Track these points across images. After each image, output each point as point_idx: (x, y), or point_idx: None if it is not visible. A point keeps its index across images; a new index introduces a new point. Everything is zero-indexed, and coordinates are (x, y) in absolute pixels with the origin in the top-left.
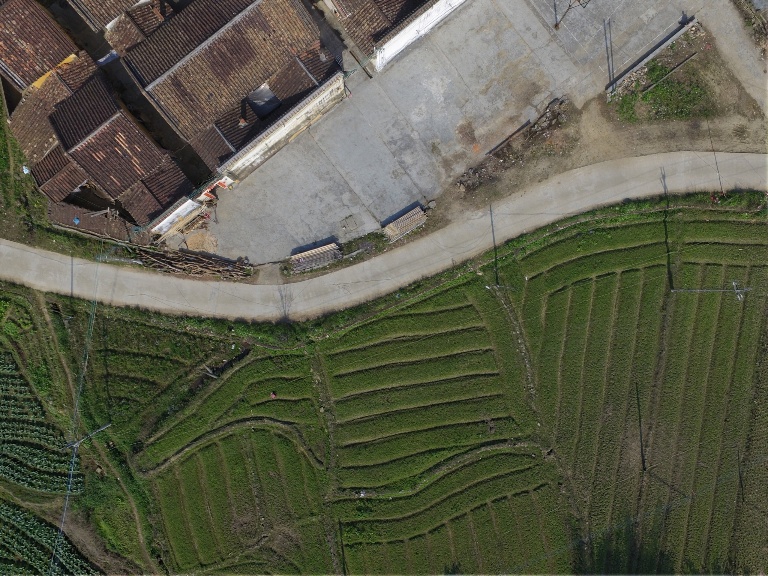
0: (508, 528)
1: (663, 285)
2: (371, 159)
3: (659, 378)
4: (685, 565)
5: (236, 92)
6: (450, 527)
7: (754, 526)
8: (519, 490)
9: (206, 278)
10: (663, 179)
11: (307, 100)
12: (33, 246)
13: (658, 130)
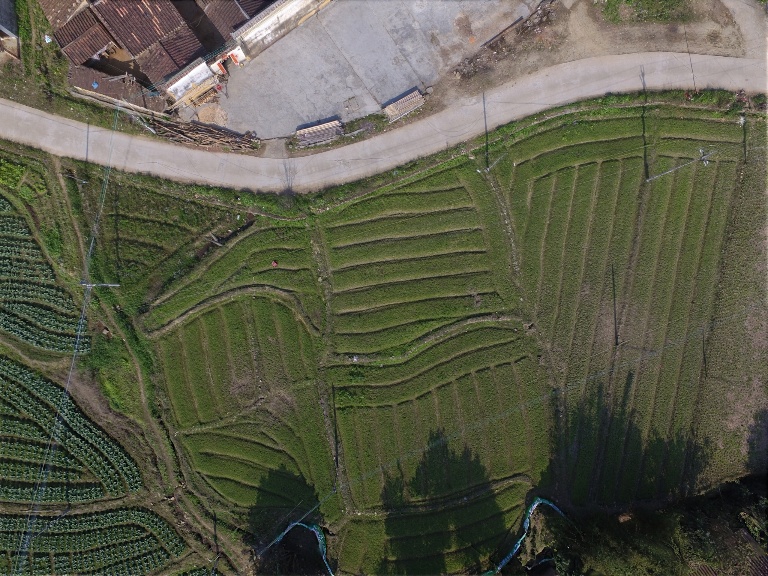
0: (490, 396)
1: (639, 175)
2: (374, 45)
3: (633, 261)
4: (651, 434)
5: None
6: (436, 394)
7: (715, 400)
8: (501, 362)
9: (215, 149)
10: (642, 76)
11: None
12: (51, 113)
13: (639, 31)
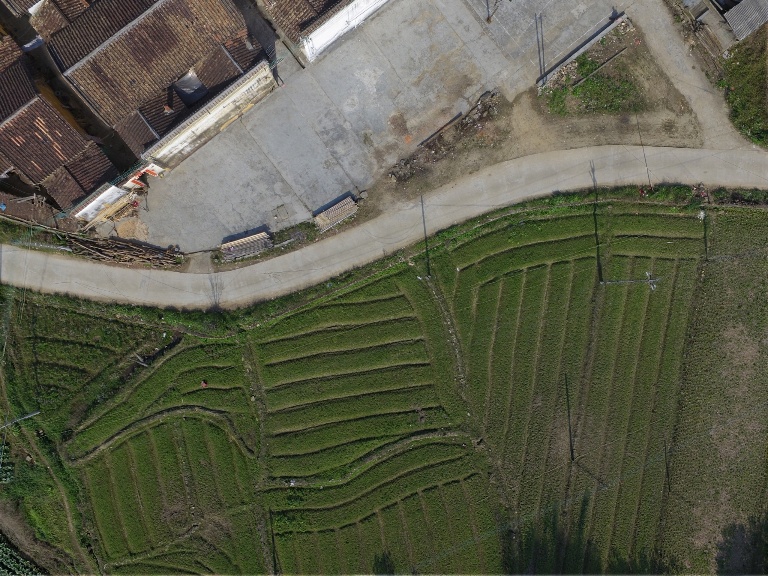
0: (438, 517)
1: (593, 277)
2: (303, 149)
3: (588, 369)
4: (612, 554)
5: (159, 79)
6: (381, 516)
7: (680, 516)
8: (449, 480)
9: (137, 266)
10: (592, 172)
11: (231, 88)
12: None
13: (588, 124)
